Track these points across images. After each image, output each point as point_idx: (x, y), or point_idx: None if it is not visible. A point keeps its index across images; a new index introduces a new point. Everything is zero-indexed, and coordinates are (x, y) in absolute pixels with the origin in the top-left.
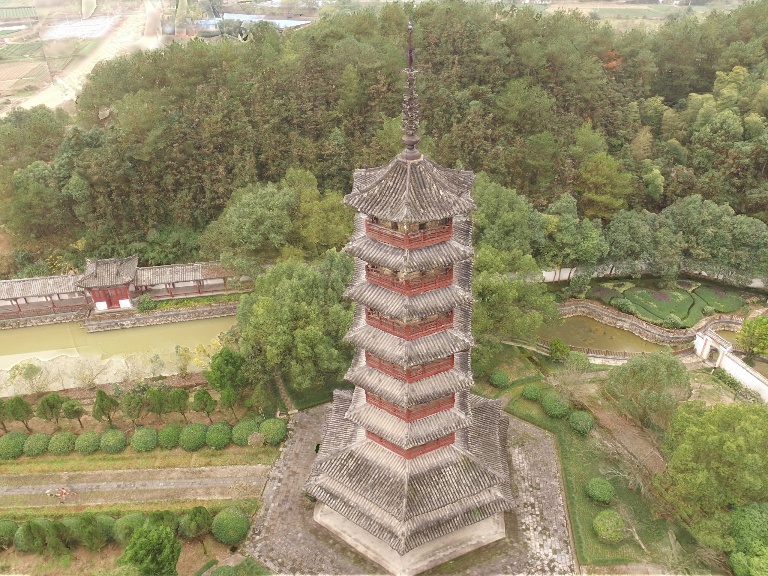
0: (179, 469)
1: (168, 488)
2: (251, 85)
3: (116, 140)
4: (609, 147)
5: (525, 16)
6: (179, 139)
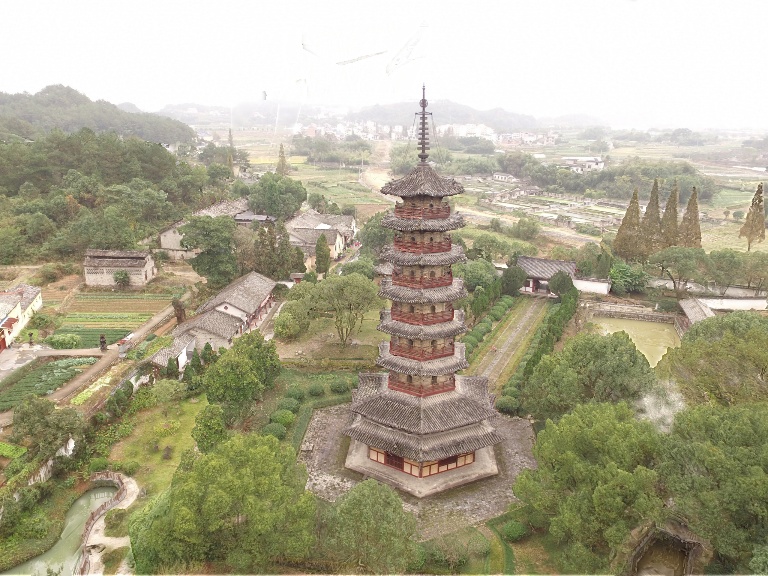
0: None
1: (482, 374)
2: None
3: None
4: None
5: None
6: None
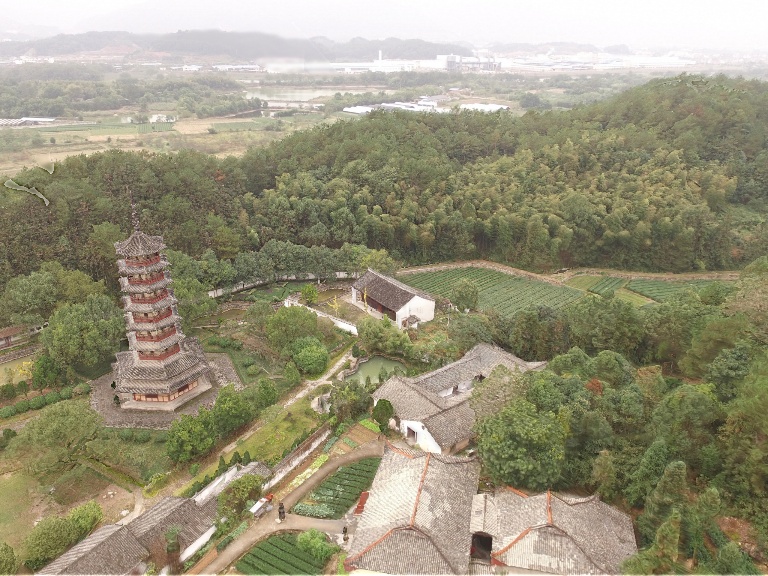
0: None
1: None
2: None
3: None
4: (228, 223)
5: (163, 159)
6: None
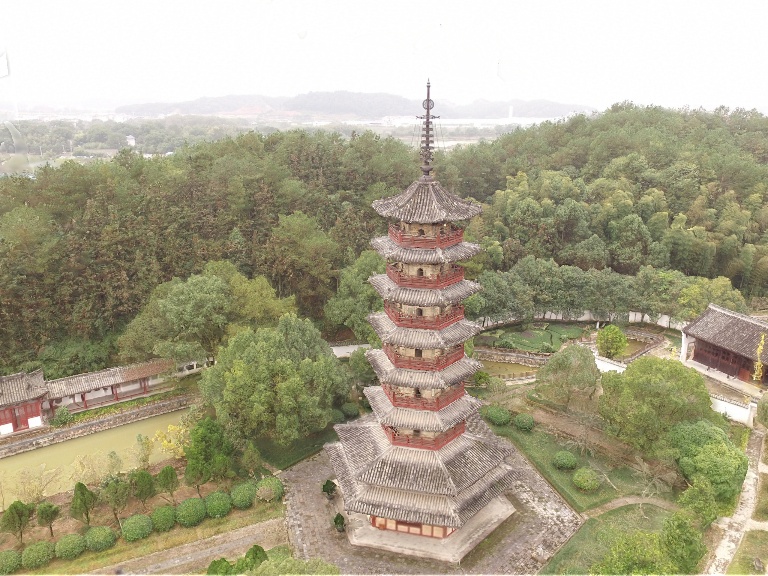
0: (189, 544)
1: (187, 562)
2: (142, 197)
3: (5, 254)
4: None
5: (368, 137)
6: (74, 250)
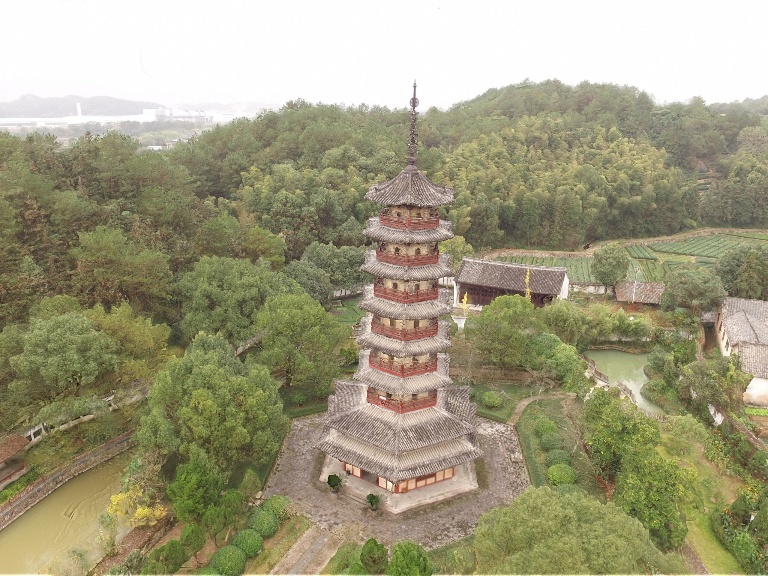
0: None
1: None
2: None
3: None
4: None
5: (116, 139)
6: None
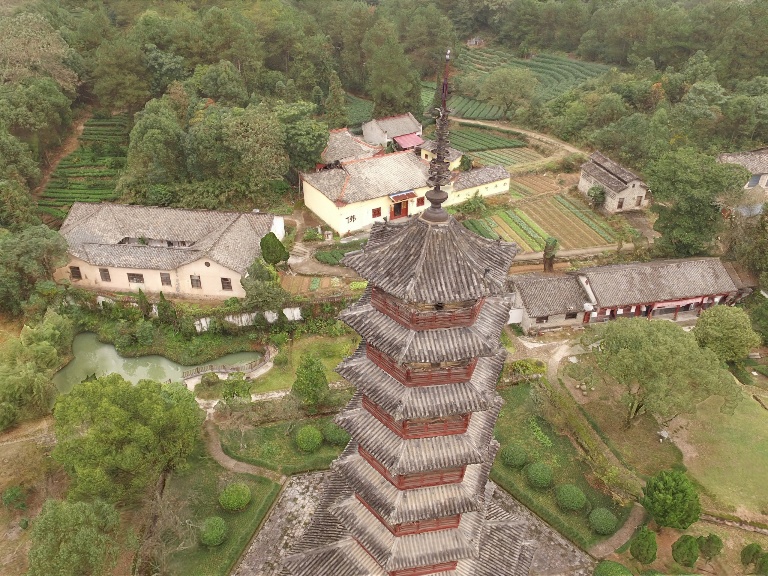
0: None
1: None
2: None
3: None
4: None
5: None
6: None
